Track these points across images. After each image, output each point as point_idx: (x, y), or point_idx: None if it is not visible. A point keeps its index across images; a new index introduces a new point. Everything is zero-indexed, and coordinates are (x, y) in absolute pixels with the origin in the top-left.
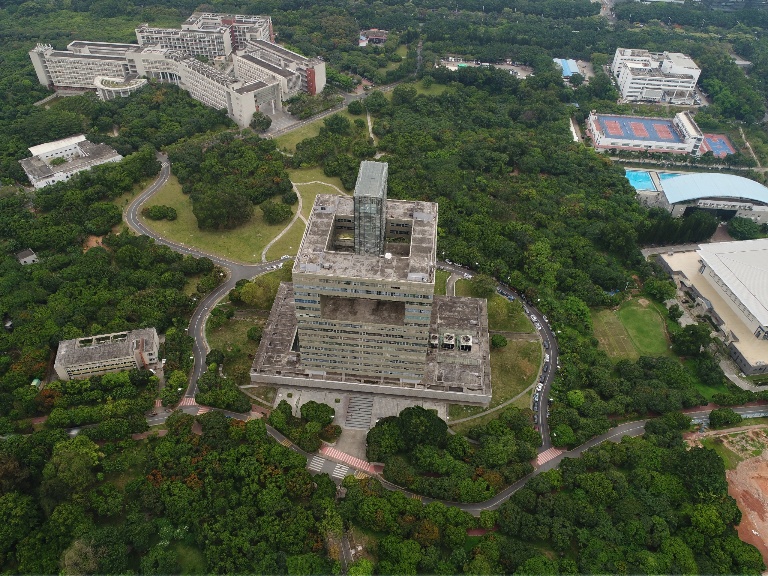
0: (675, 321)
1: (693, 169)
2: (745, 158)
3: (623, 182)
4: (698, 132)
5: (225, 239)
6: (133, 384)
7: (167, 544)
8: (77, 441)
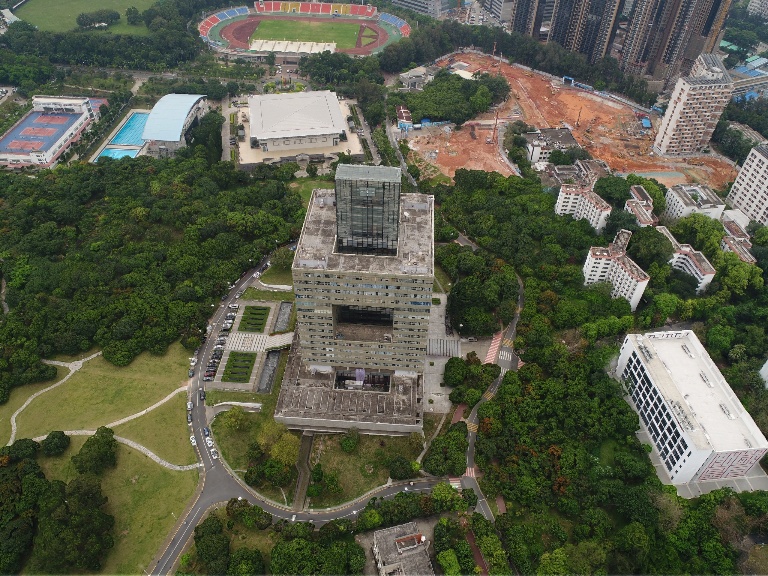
0: (315, 176)
1: (113, 125)
2: (125, 92)
3: (131, 159)
4: (77, 99)
5: (134, 527)
6: (452, 548)
7: (609, 467)
8: (553, 568)
